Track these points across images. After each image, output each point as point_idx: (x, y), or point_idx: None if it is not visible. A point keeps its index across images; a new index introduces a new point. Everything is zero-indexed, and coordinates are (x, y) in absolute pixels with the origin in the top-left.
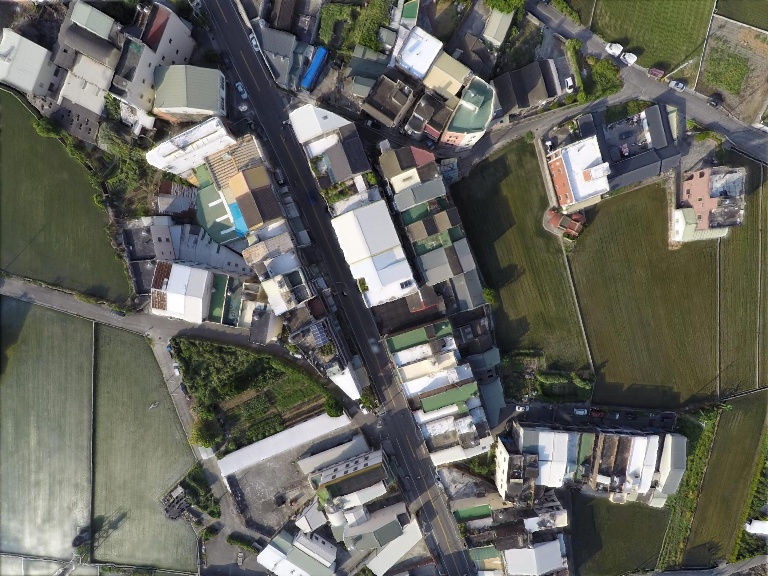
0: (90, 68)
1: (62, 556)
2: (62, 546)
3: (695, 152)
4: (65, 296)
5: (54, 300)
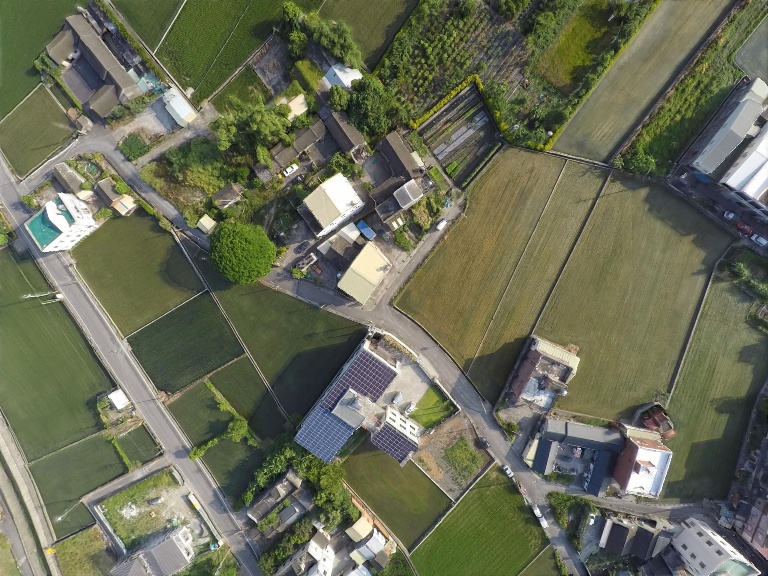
0: None
1: None
2: None
3: (517, 415)
4: None
5: None
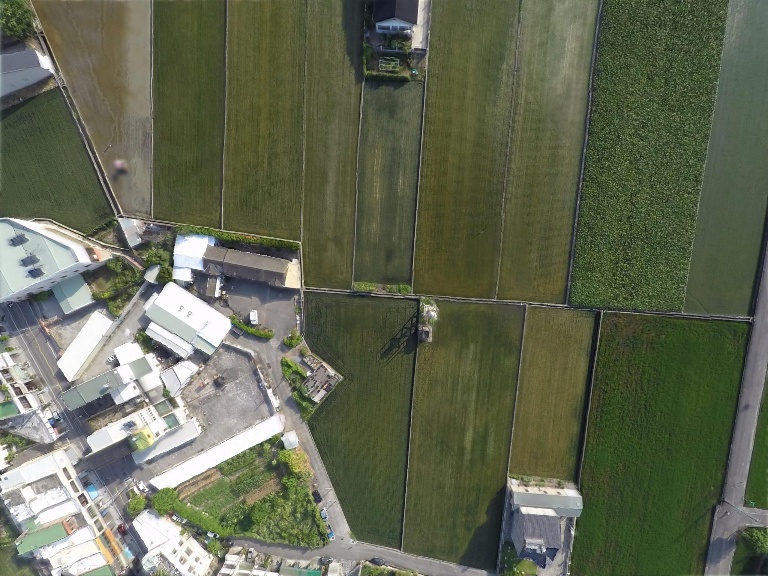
0: None
1: (451, 305)
2: (450, 317)
3: None
4: (427, 572)
5: (437, 568)
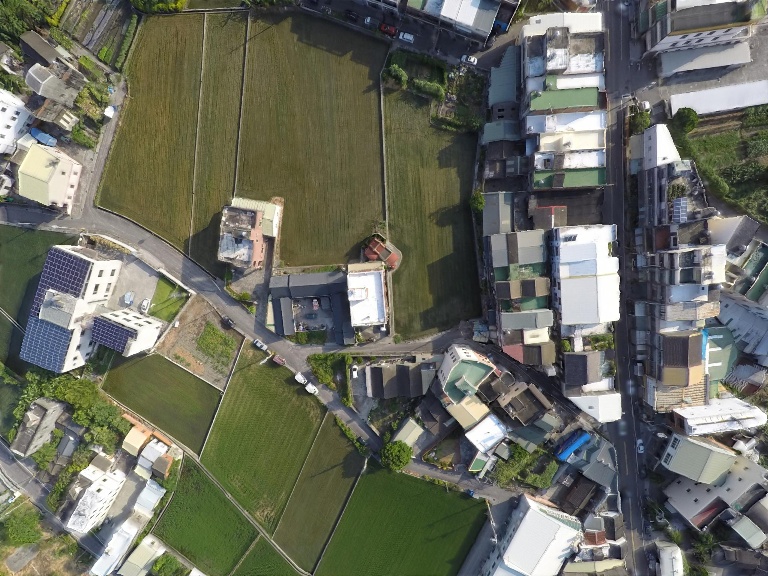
0: (766, 499)
1: None
2: None
3: (250, 284)
4: None
5: None
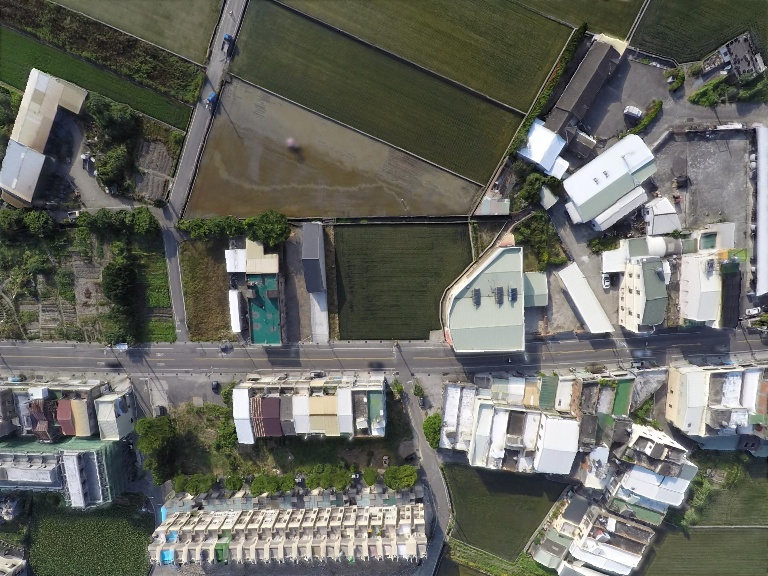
0: None
1: None
2: None
3: None
4: None
5: None
